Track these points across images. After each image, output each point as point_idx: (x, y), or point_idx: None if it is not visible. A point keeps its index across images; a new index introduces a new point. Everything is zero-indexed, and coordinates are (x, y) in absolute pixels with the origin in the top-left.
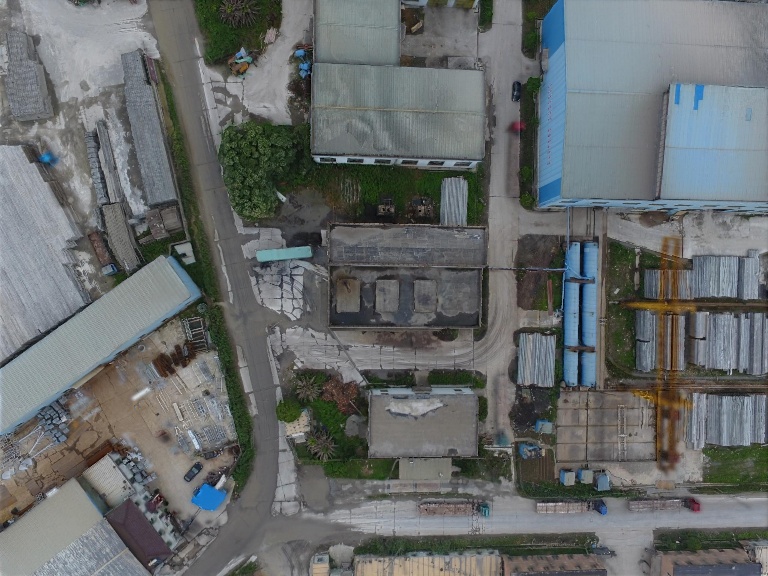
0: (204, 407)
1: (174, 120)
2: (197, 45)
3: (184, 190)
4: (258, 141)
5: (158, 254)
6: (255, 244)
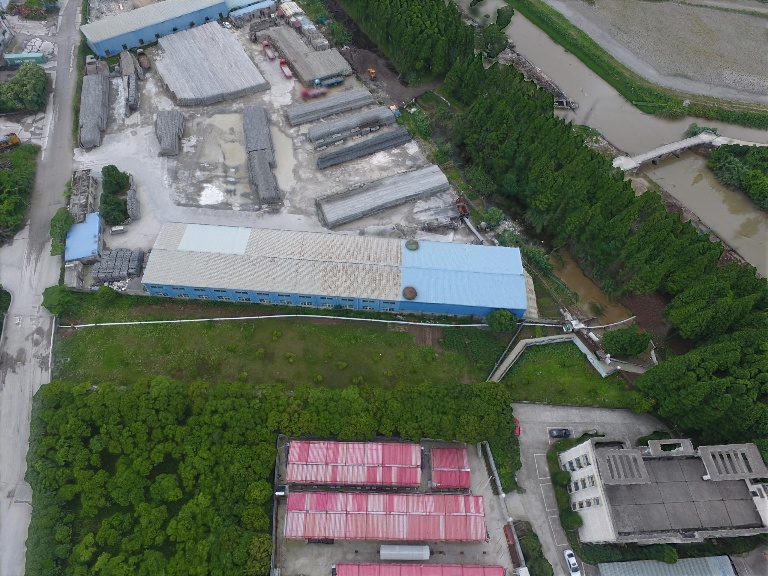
0: (106, 8)
1: (75, 116)
2: (43, 157)
3: (80, 83)
4: (6, 90)
5: (110, 60)
6: (47, 67)
